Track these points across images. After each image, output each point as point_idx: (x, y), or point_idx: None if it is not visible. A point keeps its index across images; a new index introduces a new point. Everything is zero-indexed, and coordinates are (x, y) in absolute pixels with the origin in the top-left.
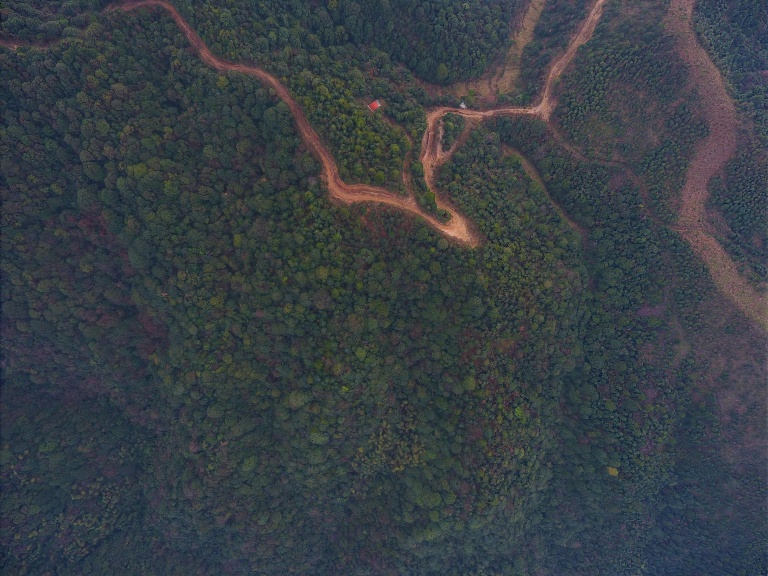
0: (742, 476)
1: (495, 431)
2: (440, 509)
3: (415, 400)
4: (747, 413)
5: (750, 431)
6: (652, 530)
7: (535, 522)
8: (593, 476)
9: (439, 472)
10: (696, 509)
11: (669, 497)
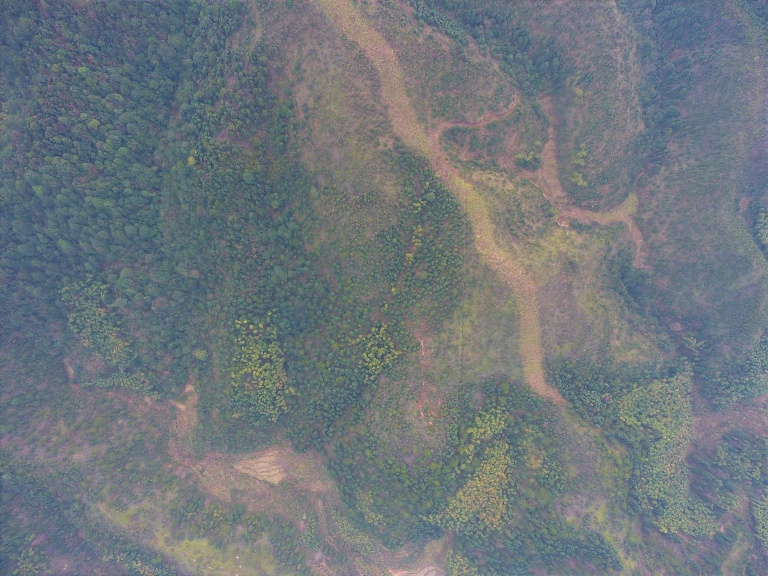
0: (323, 186)
1: (48, 78)
2: (2, 165)
3: (1, 61)
4: (313, 104)
5: (316, 125)
6: (274, 269)
7: (142, 232)
8: (180, 171)
9: (7, 129)
10: (301, 238)
11: (274, 221)
